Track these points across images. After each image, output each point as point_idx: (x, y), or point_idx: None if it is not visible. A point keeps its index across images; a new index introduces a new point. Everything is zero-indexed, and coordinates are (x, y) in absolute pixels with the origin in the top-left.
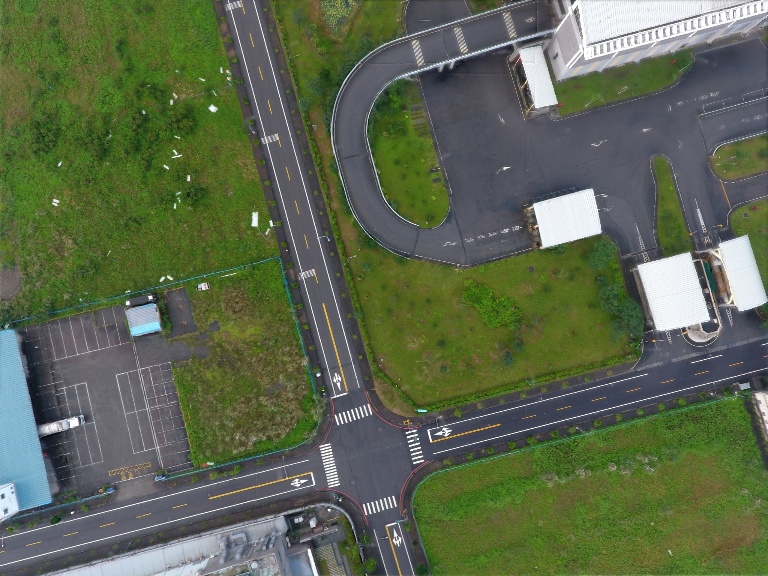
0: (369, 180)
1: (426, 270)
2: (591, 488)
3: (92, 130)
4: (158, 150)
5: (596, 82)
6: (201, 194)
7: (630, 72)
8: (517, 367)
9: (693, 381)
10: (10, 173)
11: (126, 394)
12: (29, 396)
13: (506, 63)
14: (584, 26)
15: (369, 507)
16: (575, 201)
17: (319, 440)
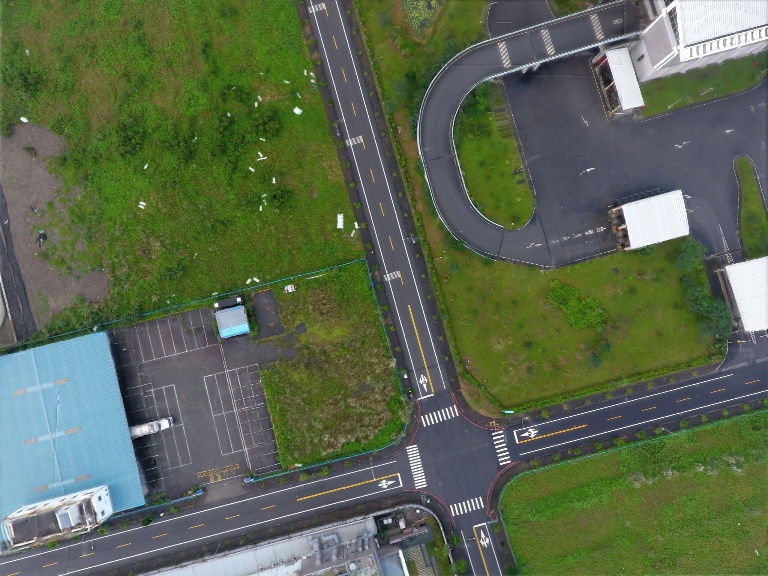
0: (454, 182)
1: (511, 271)
2: (677, 489)
3: (178, 133)
4: (244, 152)
5: (679, 83)
6: (288, 196)
7: (712, 73)
8: (602, 368)
9: None
10: (97, 176)
11: (214, 396)
12: (121, 398)
13: (589, 65)
14: (682, 28)
15: (456, 508)
16: (664, 202)
17: (406, 441)
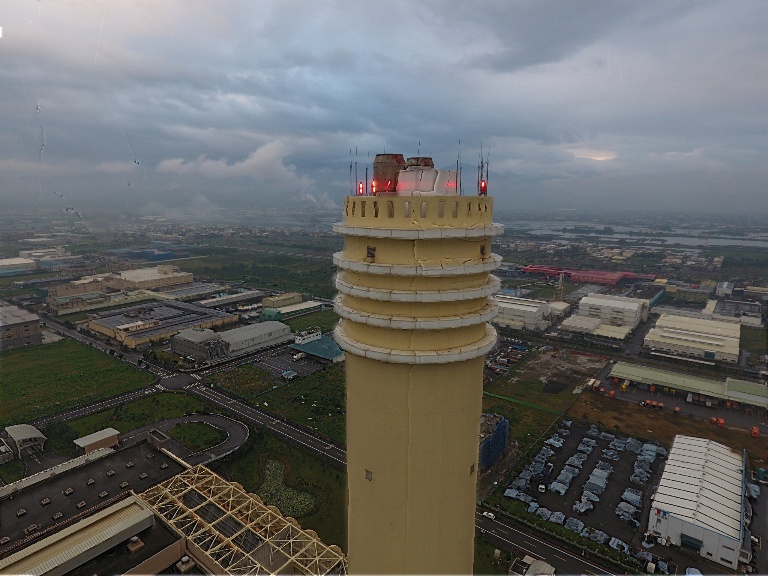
0: None
1: None
2: None
3: None
4: None
5: None
6: None
7: None
8: None
9: (3, 434)
10: None
11: None
12: None
13: None
14: None
15: None
16: None
17: None
